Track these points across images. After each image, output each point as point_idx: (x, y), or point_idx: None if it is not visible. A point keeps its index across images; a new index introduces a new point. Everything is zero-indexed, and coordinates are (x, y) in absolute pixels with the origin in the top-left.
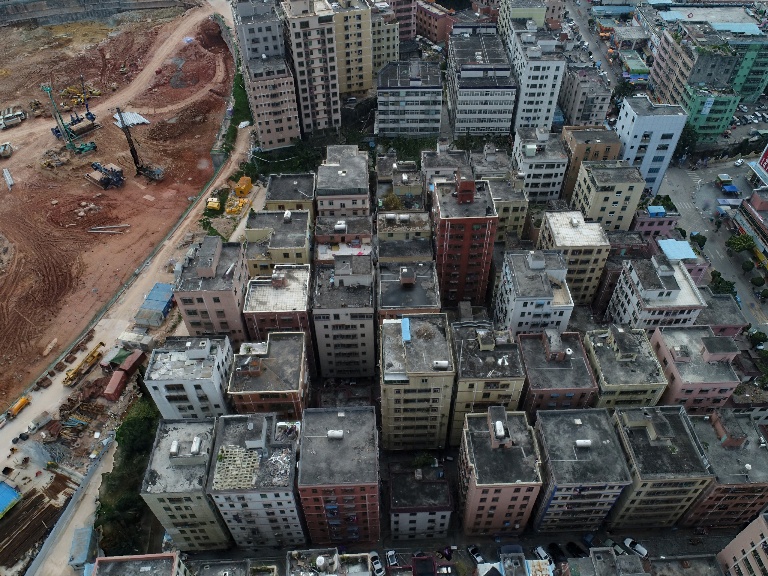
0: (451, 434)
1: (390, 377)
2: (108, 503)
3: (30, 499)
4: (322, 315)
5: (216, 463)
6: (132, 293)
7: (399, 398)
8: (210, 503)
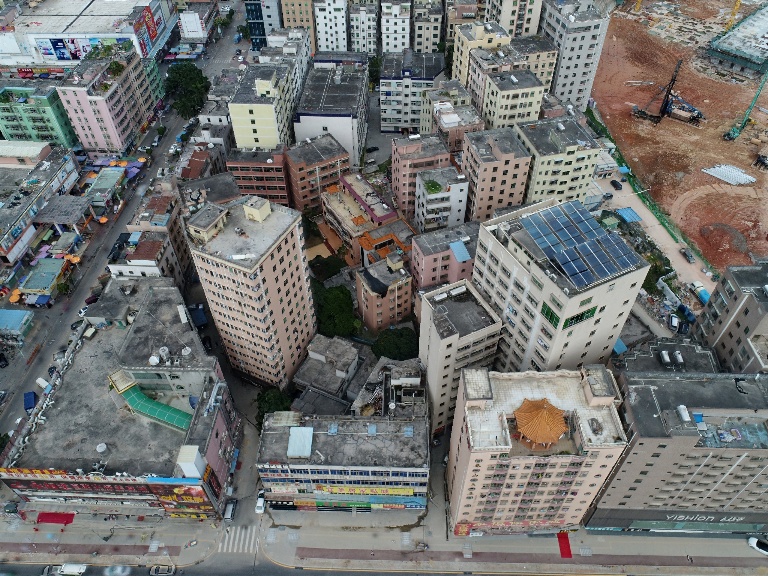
0: None
1: None
2: None
3: None
4: None
5: None
6: None
7: None
8: None
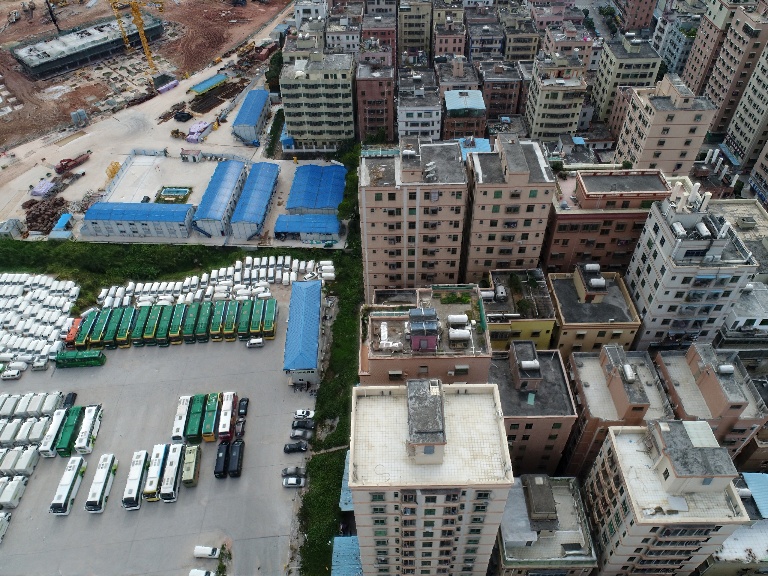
0: (431, 57)
1: (402, 7)
2: (272, 72)
3: (231, 84)
4: (371, 1)
5: (328, 27)
6: (264, 31)
7: (406, 23)
8: (324, 45)
